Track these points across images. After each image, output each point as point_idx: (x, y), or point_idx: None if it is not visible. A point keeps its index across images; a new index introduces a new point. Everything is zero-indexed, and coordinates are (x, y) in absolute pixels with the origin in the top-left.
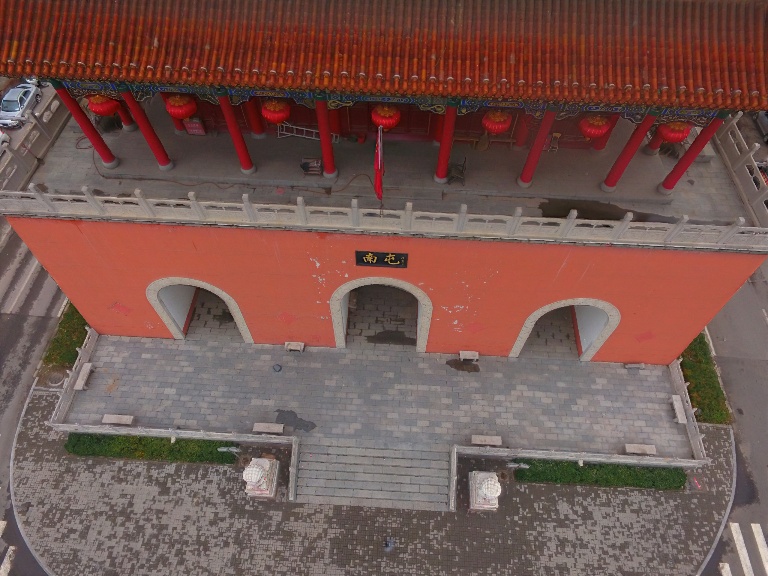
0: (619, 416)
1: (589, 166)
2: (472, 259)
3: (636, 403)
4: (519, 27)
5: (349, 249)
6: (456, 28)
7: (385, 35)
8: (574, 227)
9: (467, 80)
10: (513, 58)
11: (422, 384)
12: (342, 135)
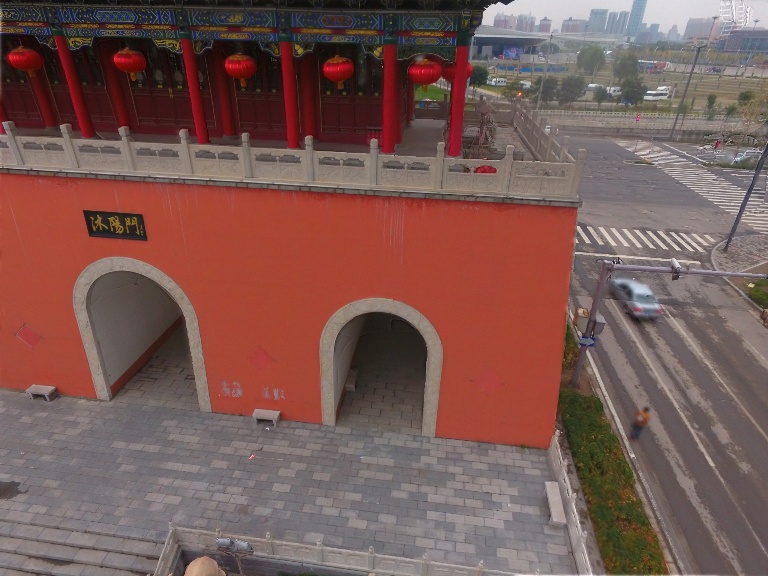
0: None
1: None
2: None
3: None
4: None
5: None
6: None
7: None
8: None
9: None
10: None
11: None
12: None
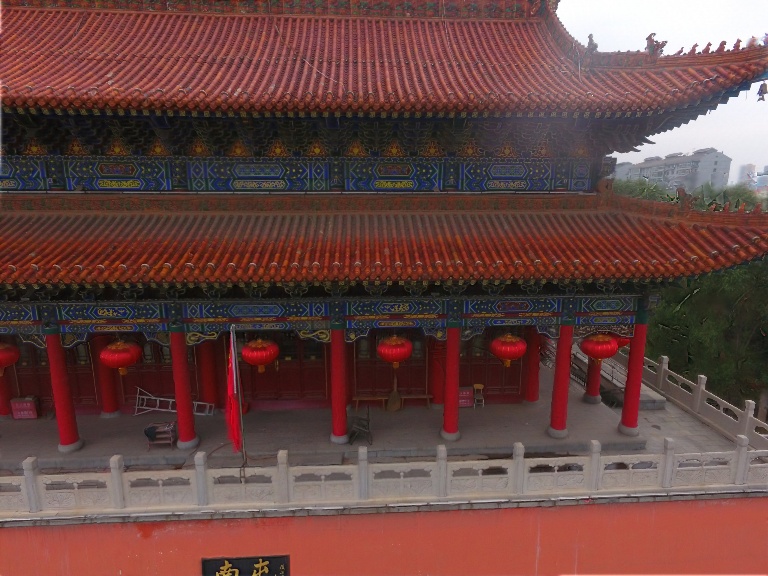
0: None
1: (527, 417)
2: (394, 555)
3: None
4: (391, 234)
5: (191, 556)
6: (325, 237)
7: (248, 243)
8: (528, 474)
9: (335, 264)
10: (387, 251)
11: None
12: (219, 406)
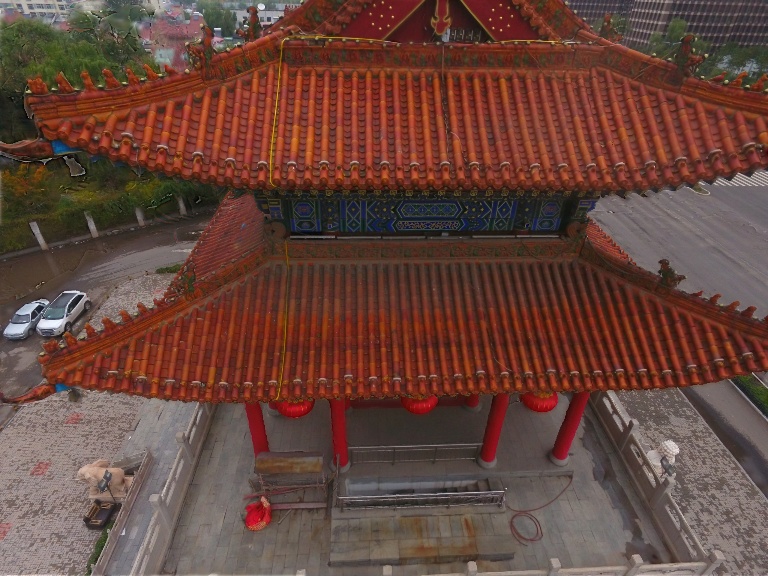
0: None
1: None
2: None
3: None
4: None
5: None
6: None
7: None
8: None
9: None
10: None
11: None
12: None
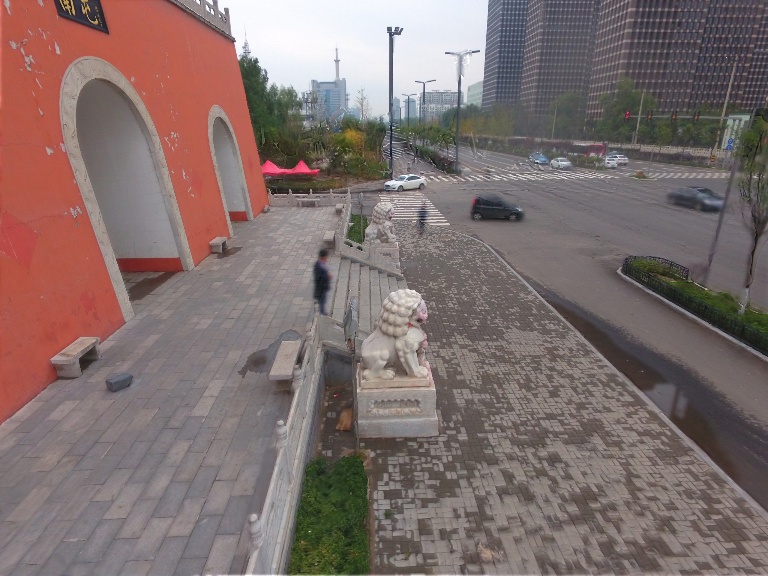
0: (310, 215)
1: None
2: (145, 24)
3: (300, 212)
4: None
5: None
6: None
7: None
8: None
9: None
10: None
11: (244, 268)
12: None
